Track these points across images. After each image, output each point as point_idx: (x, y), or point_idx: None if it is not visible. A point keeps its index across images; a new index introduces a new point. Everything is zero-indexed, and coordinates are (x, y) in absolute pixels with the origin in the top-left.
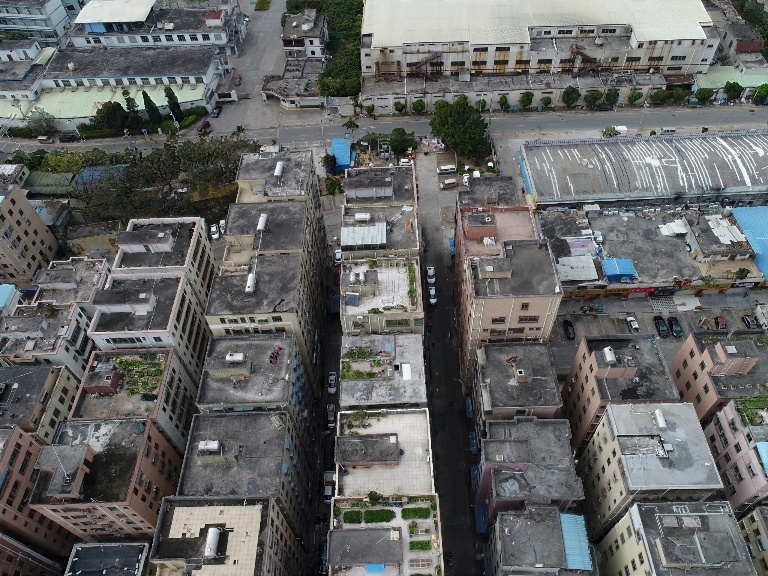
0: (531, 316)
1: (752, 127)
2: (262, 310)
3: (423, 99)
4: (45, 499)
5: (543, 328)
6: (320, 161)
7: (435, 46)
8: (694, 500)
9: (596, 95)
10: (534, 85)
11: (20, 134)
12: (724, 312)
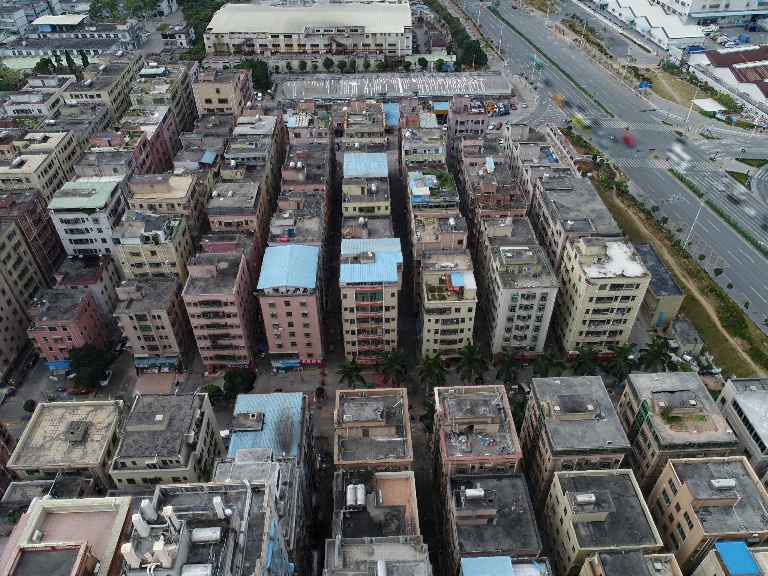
0: (224, 99)
1: None
2: None
3: None
4: None
5: (233, 108)
6: None
7: (249, 35)
8: None
9: (342, 62)
10: (308, 58)
11: None
12: None
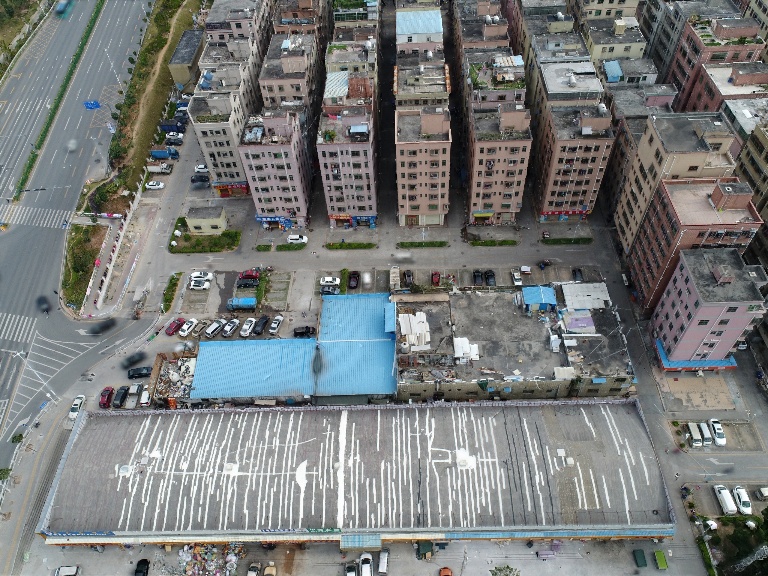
0: None
1: None
2: None
3: None
4: None
5: None
6: None
7: None
8: None
9: None
10: None
11: None
12: None
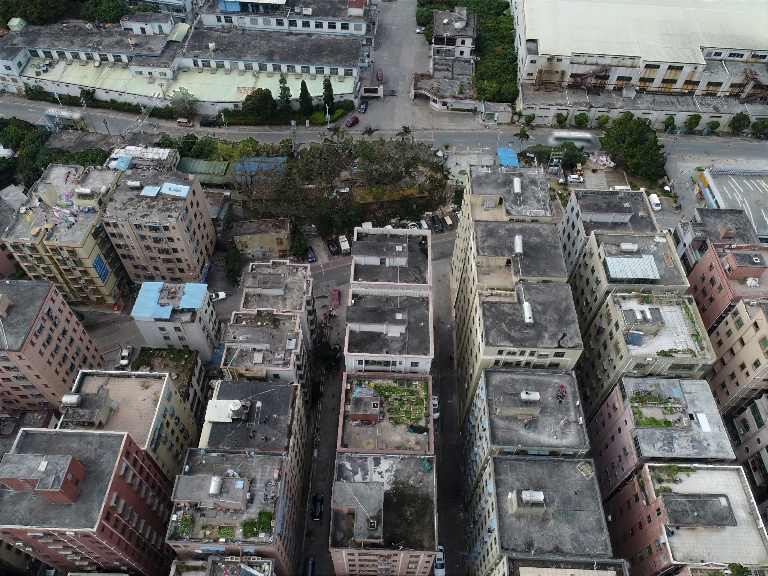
0: None
1: None
2: (546, 344)
3: (586, 113)
4: (341, 541)
5: None
6: None
7: (604, 58)
8: None
9: (767, 124)
10: (702, 108)
11: (158, 114)
12: None
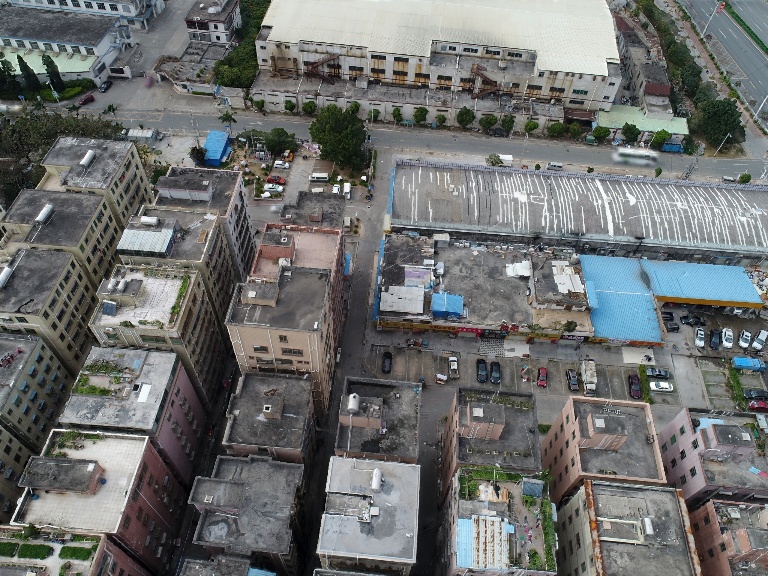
0: (294, 349)
1: (642, 173)
2: (5, 308)
3: (315, 101)
4: None
5: (311, 363)
6: (189, 152)
7: (333, 47)
8: (394, 570)
9: (490, 120)
10: (430, 101)
11: None
12: (551, 363)
